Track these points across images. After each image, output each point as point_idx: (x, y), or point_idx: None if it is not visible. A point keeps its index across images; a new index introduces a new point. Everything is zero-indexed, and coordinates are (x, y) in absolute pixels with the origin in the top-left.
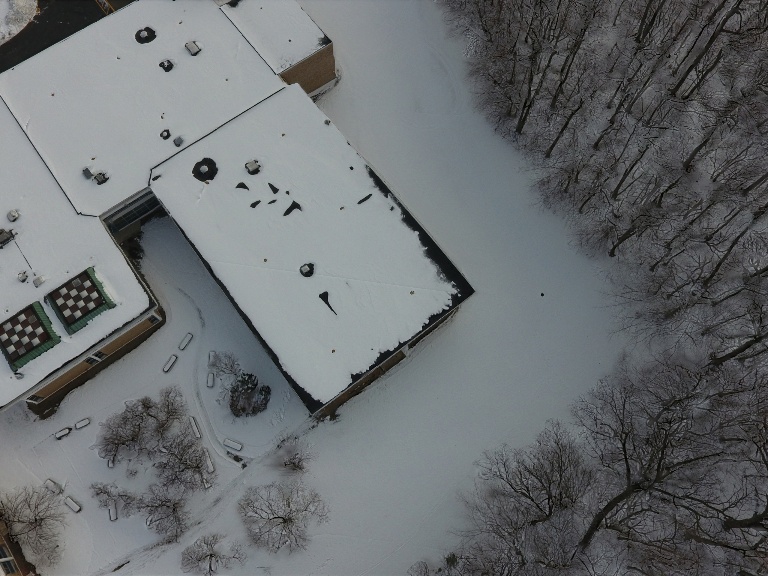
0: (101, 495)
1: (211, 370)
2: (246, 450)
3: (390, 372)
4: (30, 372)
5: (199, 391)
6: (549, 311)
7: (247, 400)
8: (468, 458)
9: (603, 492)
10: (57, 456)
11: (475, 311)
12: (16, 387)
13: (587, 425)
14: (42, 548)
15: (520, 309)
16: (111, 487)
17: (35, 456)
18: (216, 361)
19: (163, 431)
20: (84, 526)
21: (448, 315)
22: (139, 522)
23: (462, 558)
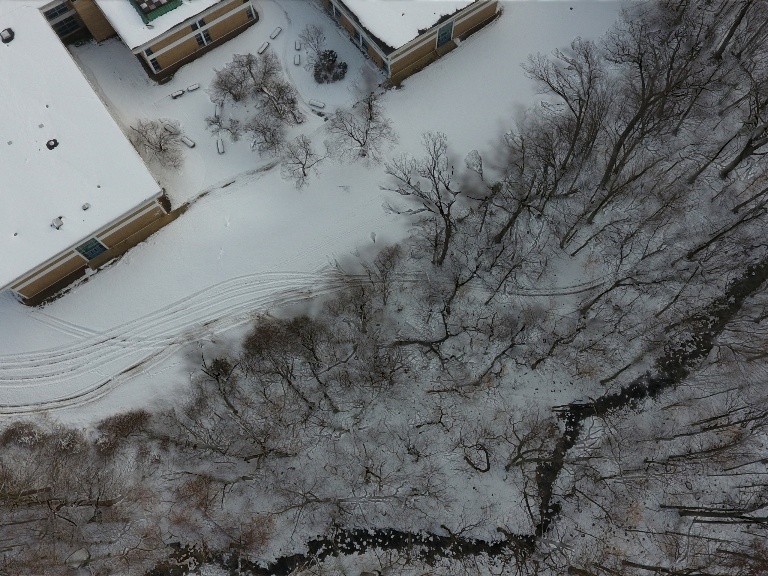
0: (214, 125)
1: (300, 43)
2: (328, 108)
3: (445, 57)
4: (159, 24)
5: (288, 68)
6: (577, 20)
7: (328, 71)
8: (510, 120)
9: (623, 104)
10: (173, 110)
11: (515, 17)
12: (148, 34)
13: (611, 49)
14: (168, 159)
15: (553, 18)
16: (221, 120)
17: (156, 110)
18: (304, 34)
19: (264, 76)
20: (198, 157)
21: (493, 19)
22: (242, 155)
23: (506, 181)
